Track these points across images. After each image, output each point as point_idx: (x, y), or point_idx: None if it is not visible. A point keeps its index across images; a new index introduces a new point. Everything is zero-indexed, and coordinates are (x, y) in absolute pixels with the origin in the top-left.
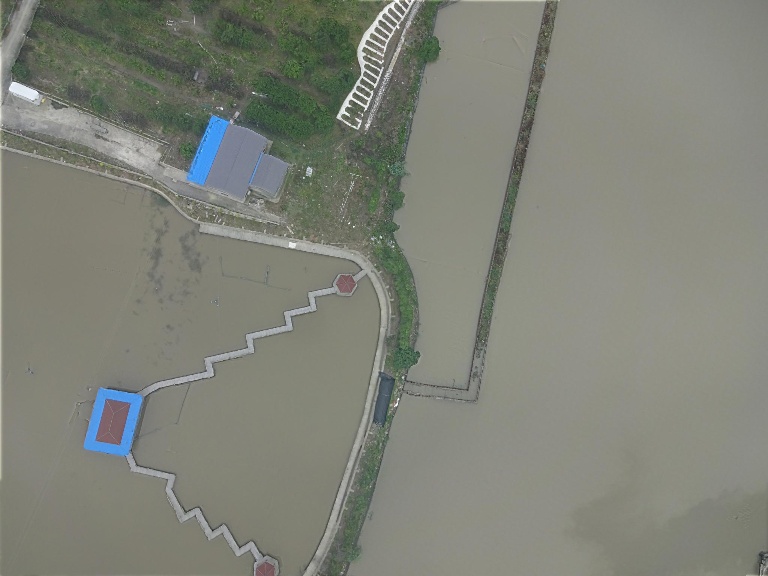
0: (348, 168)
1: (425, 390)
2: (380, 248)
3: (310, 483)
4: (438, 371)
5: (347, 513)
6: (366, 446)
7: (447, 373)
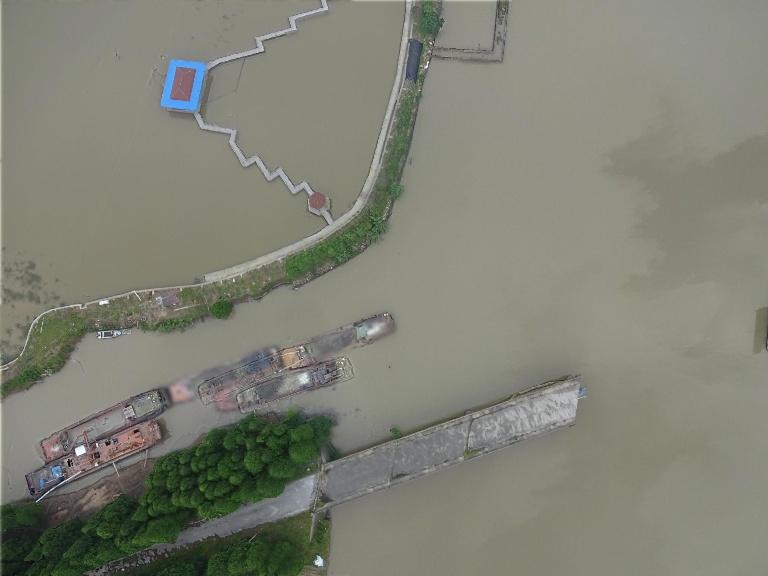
0: None
1: (452, 54)
2: None
3: (353, 134)
4: (464, 40)
5: (388, 155)
6: (401, 100)
7: (472, 40)
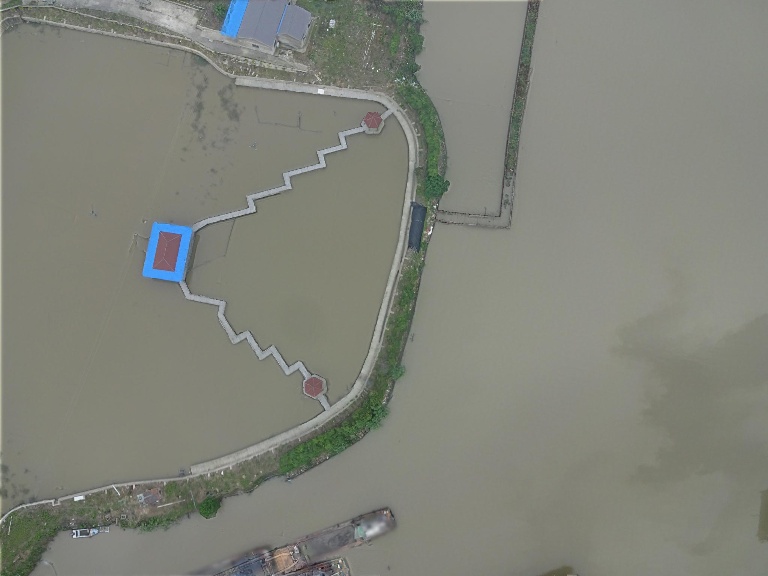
0: (368, 19)
1: (457, 219)
2: (403, 86)
3: (352, 307)
4: (469, 202)
5: (389, 333)
6: (403, 271)
7: (478, 203)
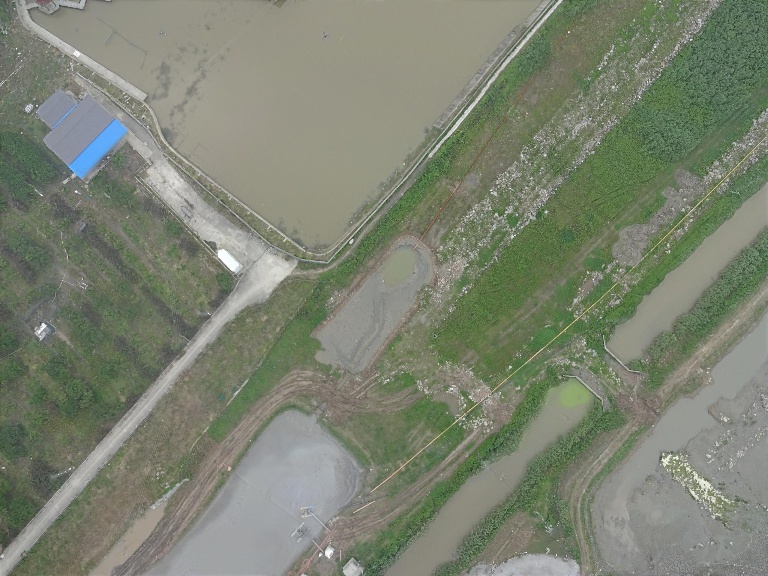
0: None
1: None
2: None
3: None
4: None
5: None
6: None
7: None
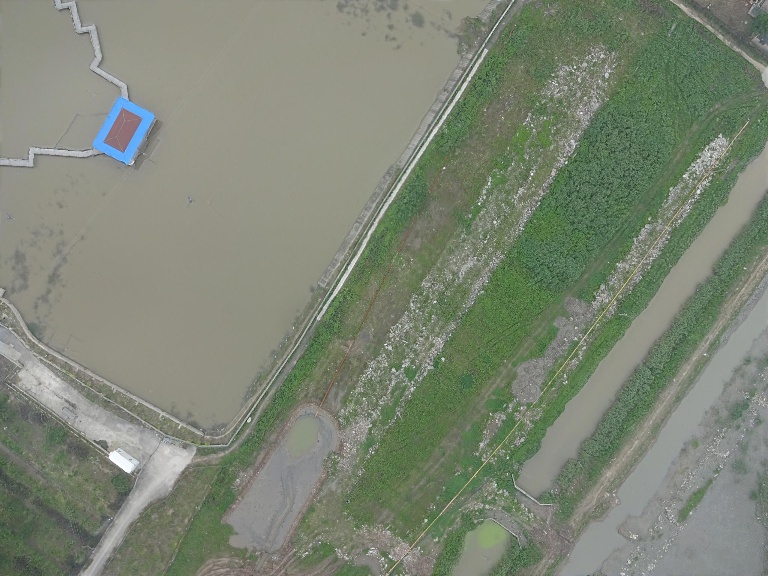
0: None
1: None
2: None
3: None
4: None
5: None
6: None
7: None
